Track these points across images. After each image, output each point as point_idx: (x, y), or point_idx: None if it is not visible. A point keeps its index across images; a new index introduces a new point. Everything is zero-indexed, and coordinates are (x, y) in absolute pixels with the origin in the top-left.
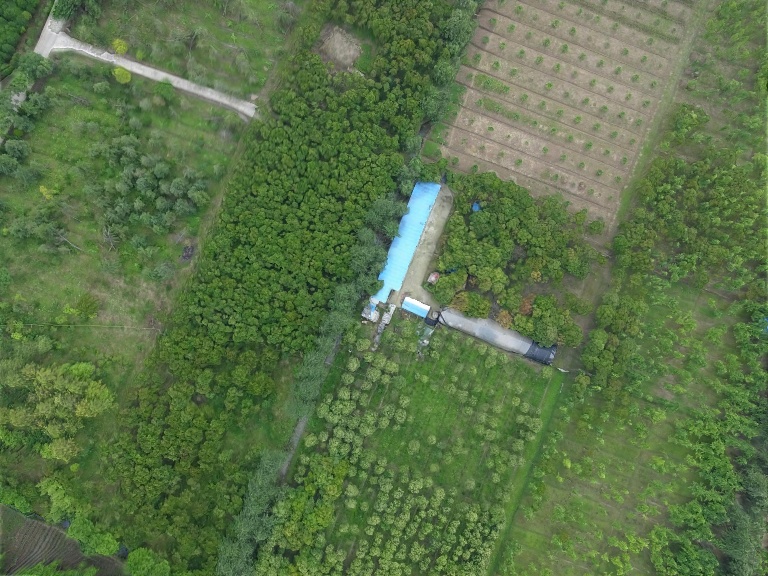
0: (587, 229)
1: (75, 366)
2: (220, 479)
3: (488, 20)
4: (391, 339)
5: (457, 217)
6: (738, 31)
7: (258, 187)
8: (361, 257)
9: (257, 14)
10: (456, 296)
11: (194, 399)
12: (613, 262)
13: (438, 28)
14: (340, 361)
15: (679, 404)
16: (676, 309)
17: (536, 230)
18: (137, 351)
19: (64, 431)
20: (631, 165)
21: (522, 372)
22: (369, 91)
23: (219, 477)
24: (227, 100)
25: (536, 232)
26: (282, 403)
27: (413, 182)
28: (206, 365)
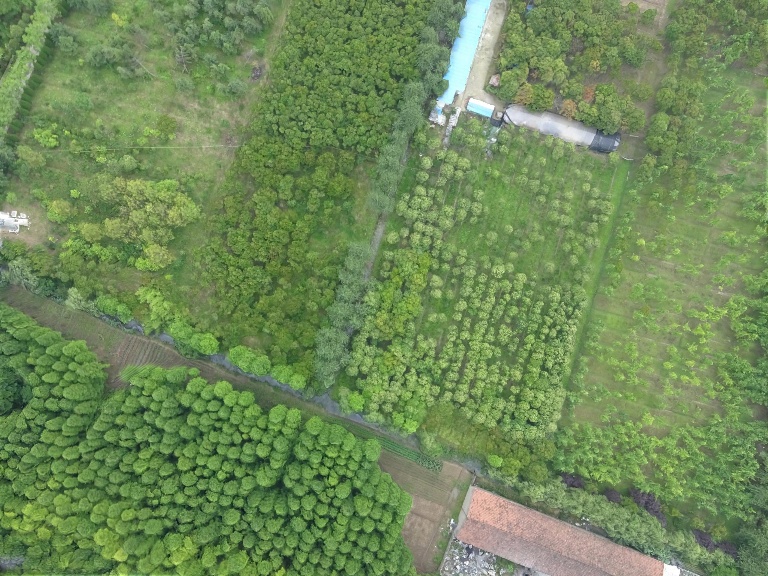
0: (639, 19)
1: (160, 182)
2: (310, 276)
3: None
4: (461, 135)
5: (514, 15)
6: None
7: None
8: (428, 51)
9: None
10: (520, 88)
11: (277, 205)
12: (667, 52)
13: None
14: (412, 165)
15: (743, 183)
16: (733, 89)
17: (592, 19)
18: (217, 169)
19: (158, 239)
20: None
21: (588, 164)
22: None
23: (308, 278)
24: None
25: (592, 21)
26: (361, 207)
27: None
28: (286, 171)
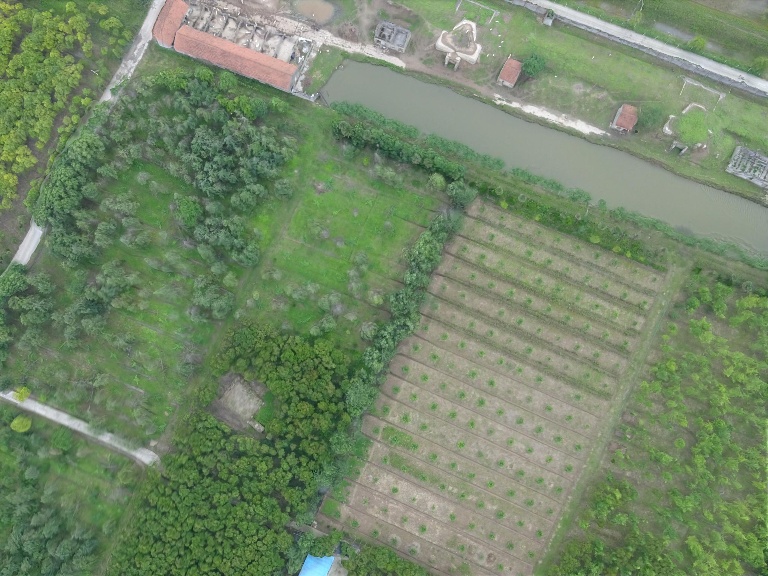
0: None
1: None
2: None
3: (401, 367)
4: None
5: None
6: (677, 396)
7: (141, 559)
8: None
9: (162, 355)
10: None
11: None
12: None
13: (340, 389)
14: None
15: None
16: None
17: None
18: None
19: None
20: (548, 537)
21: None
22: (262, 459)
23: None
24: (125, 447)
25: None
26: None
27: (304, 556)
28: None
